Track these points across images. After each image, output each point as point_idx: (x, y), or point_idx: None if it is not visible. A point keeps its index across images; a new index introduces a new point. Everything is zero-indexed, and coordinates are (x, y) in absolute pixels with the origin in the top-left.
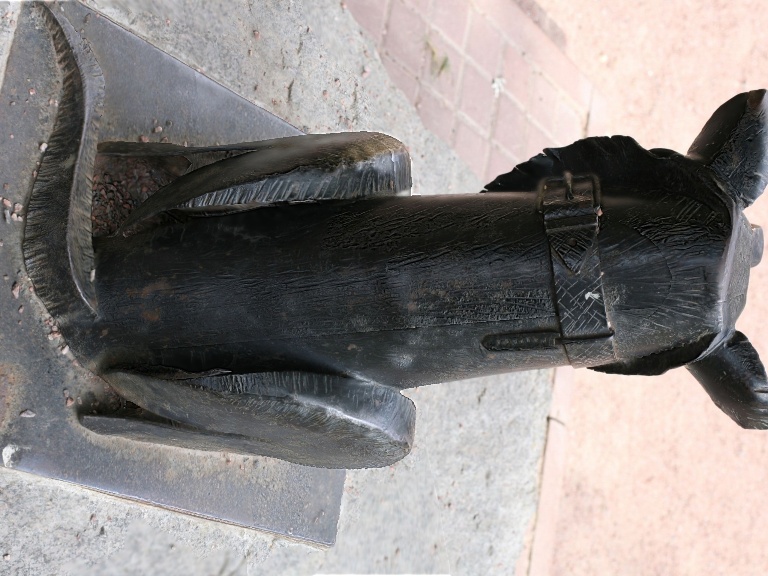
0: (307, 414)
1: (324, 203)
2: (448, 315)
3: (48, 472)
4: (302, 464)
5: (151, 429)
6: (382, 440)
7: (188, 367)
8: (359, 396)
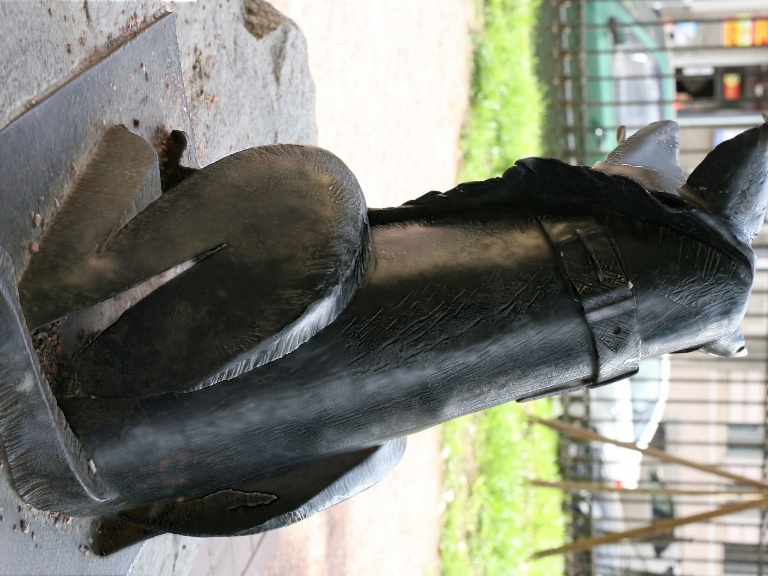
0: None
1: None
2: (491, 400)
3: None
4: None
5: None
6: None
7: None
8: (388, 453)
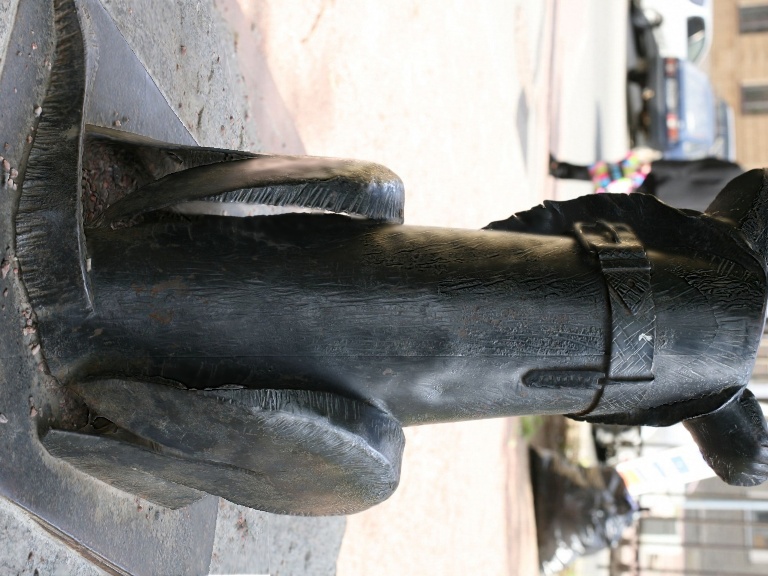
0: (333, 441)
1: (355, 219)
2: (498, 345)
3: (11, 492)
4: (262, 507)
5: (123, 452)
6: (385, 479)
7: (191, 381)
8: (379, 427)
